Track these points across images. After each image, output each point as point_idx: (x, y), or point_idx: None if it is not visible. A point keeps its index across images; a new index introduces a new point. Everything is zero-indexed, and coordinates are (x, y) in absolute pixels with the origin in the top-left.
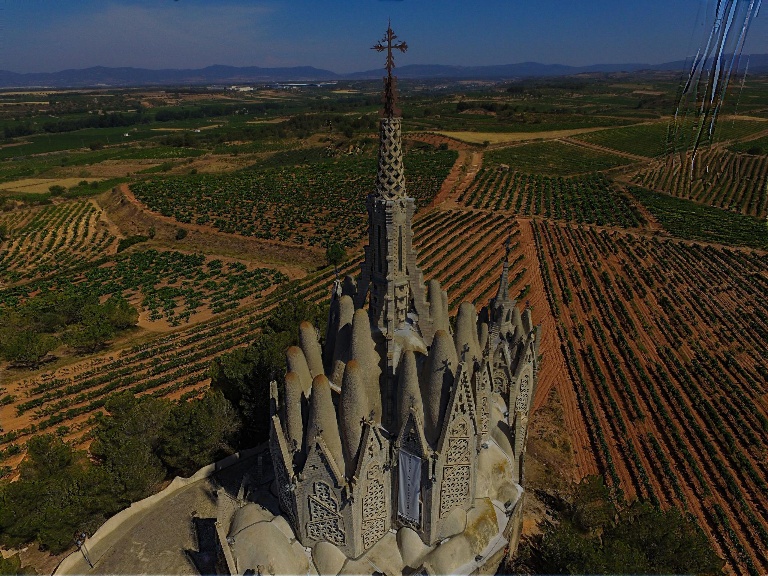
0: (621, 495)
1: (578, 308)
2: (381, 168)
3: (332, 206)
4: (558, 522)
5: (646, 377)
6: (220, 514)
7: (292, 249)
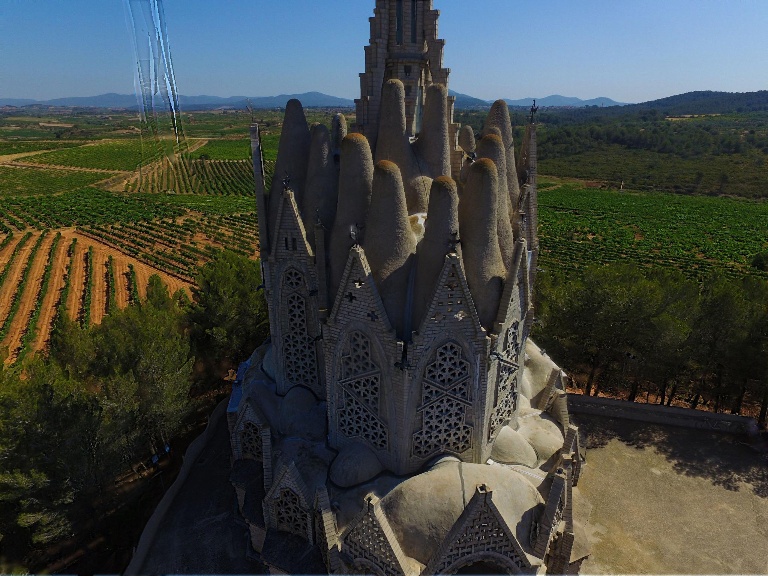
0: None
1: None
2: None
3: None
4: None
5: None
6: (394, 539)
7: None
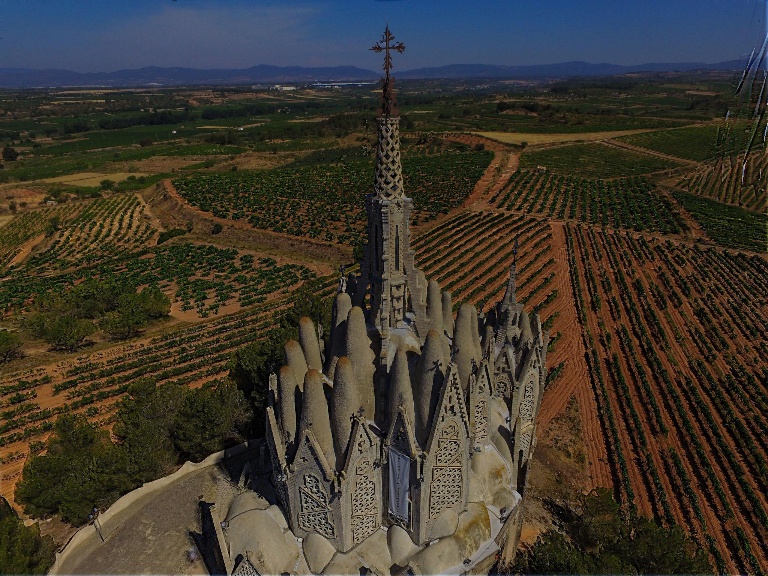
0: (634, 511)
1: (607, 316)
2: (378, 168)
3: (363, 205)
4: (564, 533)
5: (673, 390)
6: (219, 499)
7: (321, 246)
